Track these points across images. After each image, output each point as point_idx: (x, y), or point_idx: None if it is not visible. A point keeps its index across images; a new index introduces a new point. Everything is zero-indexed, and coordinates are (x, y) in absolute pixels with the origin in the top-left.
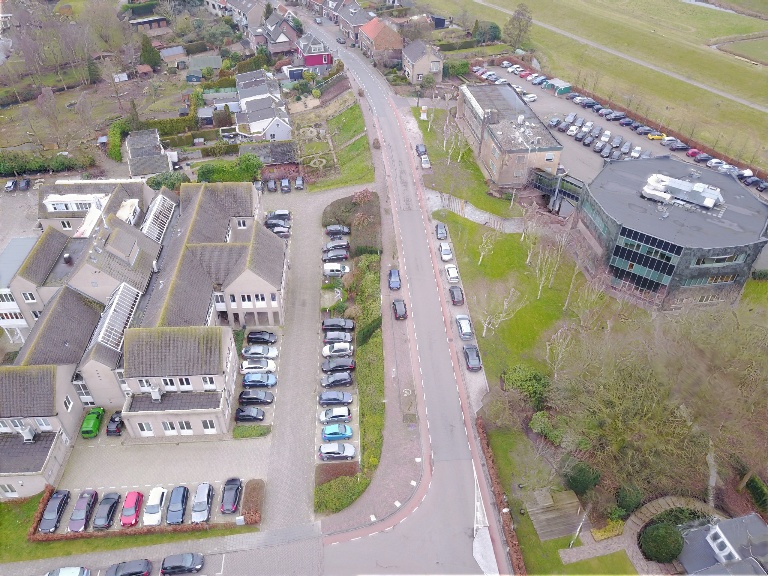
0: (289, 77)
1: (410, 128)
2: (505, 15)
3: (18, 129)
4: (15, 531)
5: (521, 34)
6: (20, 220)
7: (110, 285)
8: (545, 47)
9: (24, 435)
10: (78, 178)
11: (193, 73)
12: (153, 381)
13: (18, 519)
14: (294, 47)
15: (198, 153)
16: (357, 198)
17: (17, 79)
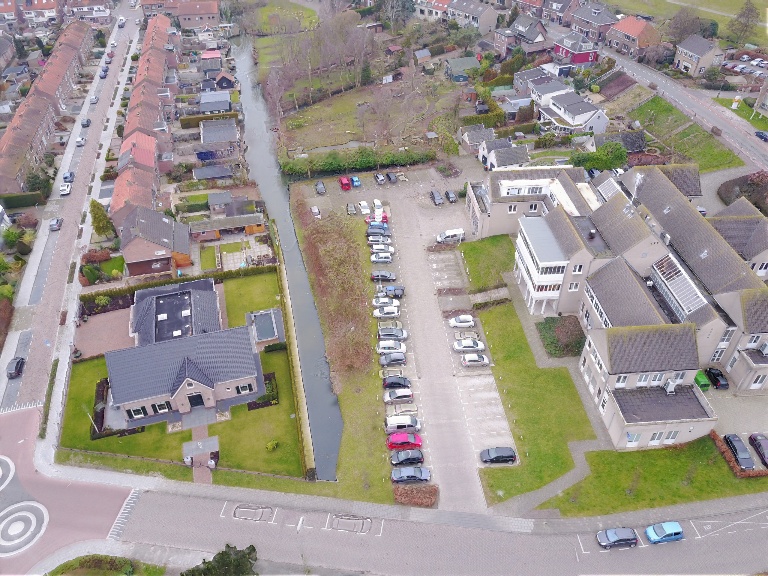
0: (558, 74)
1: (731, 117)
2: (706, 13)
3: (333, 128)
4: (710, 470)
5: (747, 29)
6: (417, 209)
7: (657, 256)
8: (767, 41)
9: (671, 387)
10: (433, 171)
11: (460, 73)
12: (765, 337)
13: (699, 461)
14: (546, 47)
15: (532, 145)
16: (757, 179)
17: (289, 83)
